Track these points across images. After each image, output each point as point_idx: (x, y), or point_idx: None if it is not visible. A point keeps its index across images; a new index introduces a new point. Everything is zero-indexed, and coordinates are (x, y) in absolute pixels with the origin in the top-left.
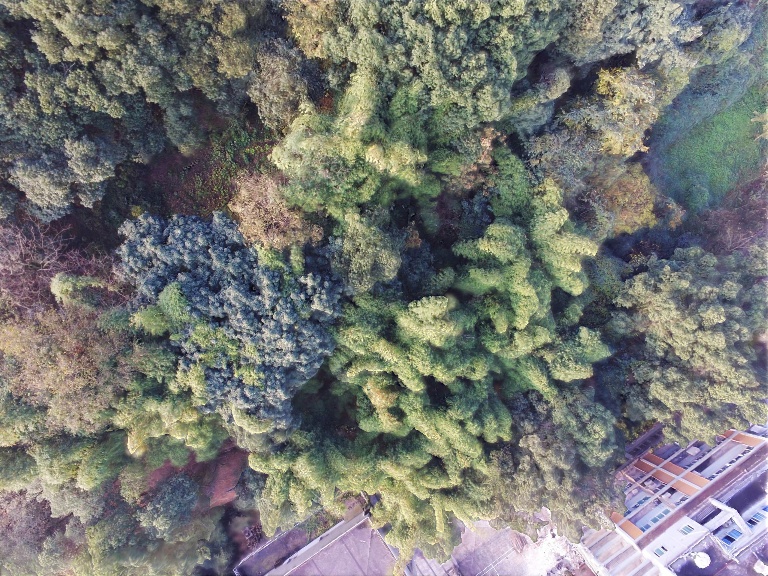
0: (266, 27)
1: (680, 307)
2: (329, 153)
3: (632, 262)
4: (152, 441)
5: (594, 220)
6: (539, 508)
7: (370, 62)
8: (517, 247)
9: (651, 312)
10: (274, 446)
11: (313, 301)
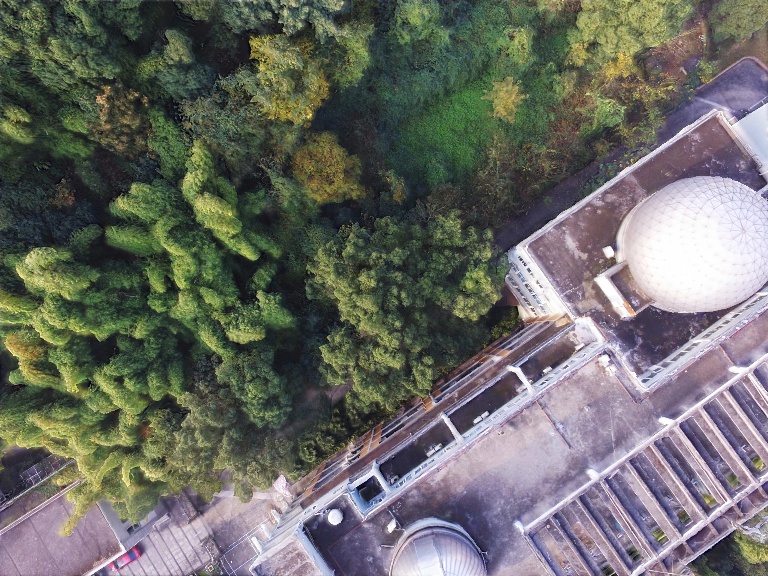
0: None
1: (346, 272)
2: None
3: (339, 232)
4: None
5: (272, 186)
6: (196, 465)
7: None
8: (159, 206)
9: (316, 276)
10: None
11: None
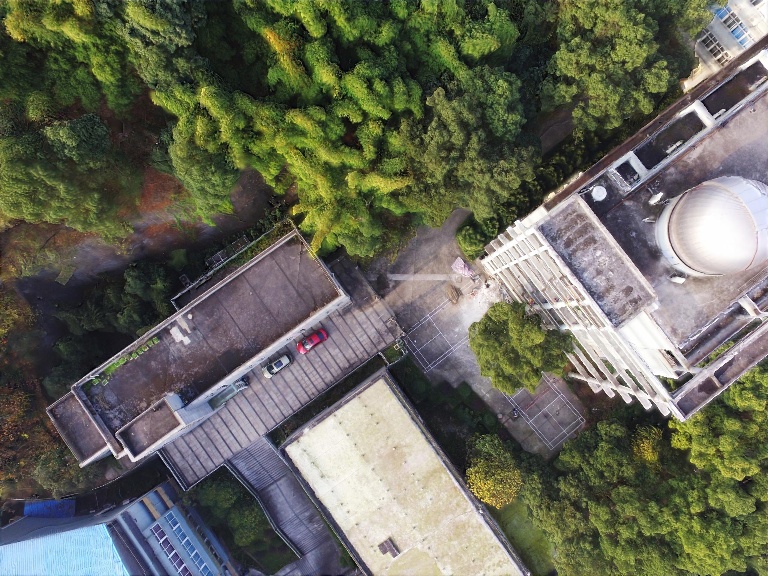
0: None
1: None
2: None
3: None
4: (61, 73)
5: None
6: (447, 165)
7: None
8: None
9: None
10: (180, 77)
11: None
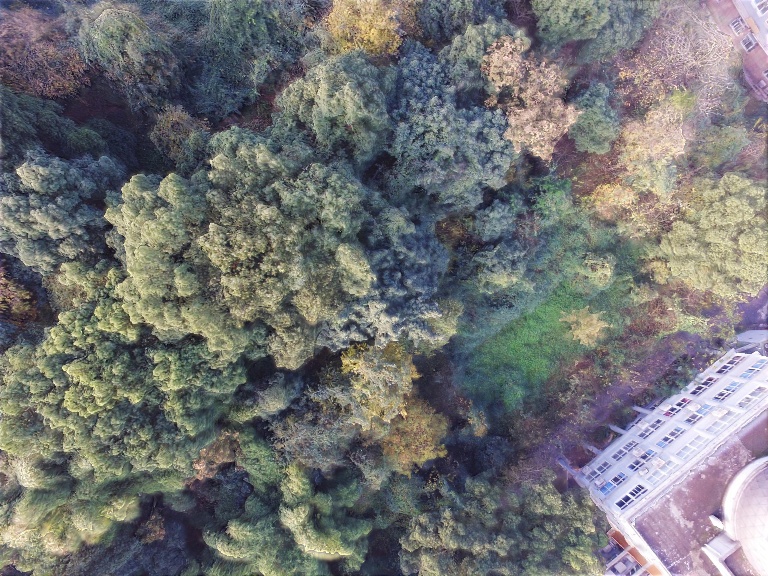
0: None
1: (450, 567)
2: None
3: (427, 489)
4: None
5: (364, 476)
6: None
7: None
8: (259, 542)
9: (419, 575)
10: None
11: None
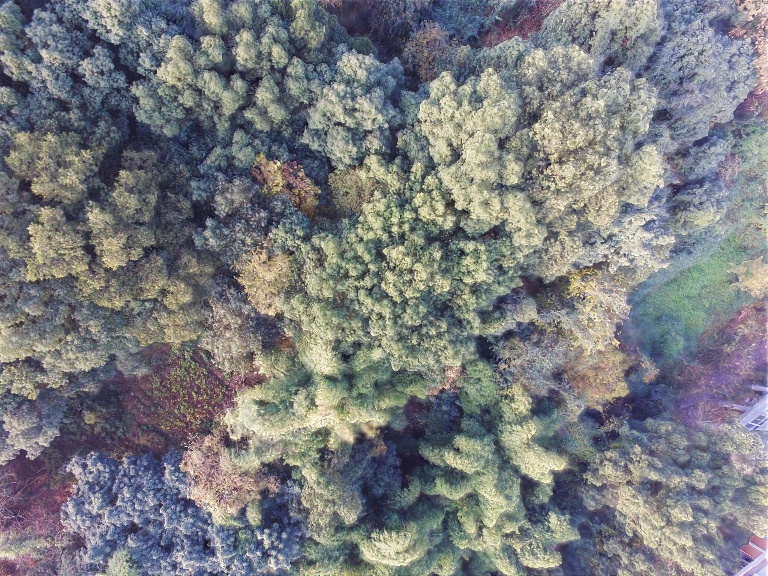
0: (218, 273)
1: (649, 498)
2: (282, 432)
3: (604, 428)
4: None
5: (565, 406)
6: None
7: (325, 335)
8: (484, 459)
9: (620, 504)
10: None
11: (270, 560)
